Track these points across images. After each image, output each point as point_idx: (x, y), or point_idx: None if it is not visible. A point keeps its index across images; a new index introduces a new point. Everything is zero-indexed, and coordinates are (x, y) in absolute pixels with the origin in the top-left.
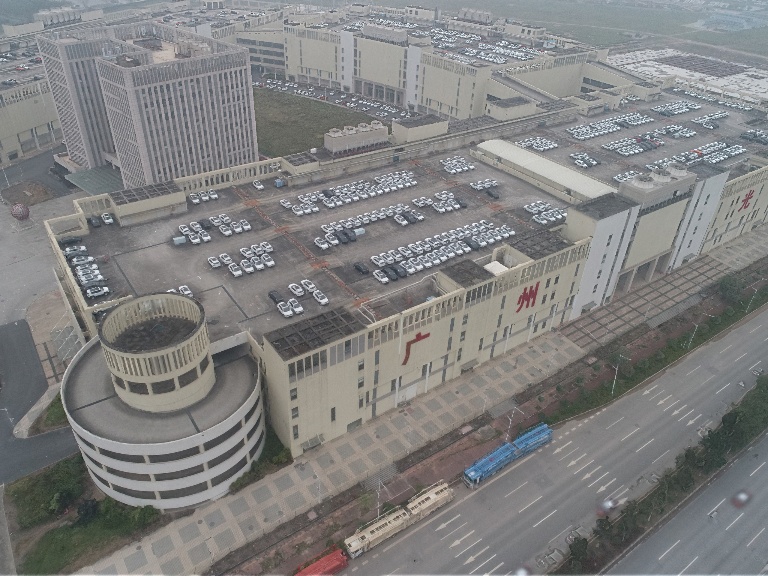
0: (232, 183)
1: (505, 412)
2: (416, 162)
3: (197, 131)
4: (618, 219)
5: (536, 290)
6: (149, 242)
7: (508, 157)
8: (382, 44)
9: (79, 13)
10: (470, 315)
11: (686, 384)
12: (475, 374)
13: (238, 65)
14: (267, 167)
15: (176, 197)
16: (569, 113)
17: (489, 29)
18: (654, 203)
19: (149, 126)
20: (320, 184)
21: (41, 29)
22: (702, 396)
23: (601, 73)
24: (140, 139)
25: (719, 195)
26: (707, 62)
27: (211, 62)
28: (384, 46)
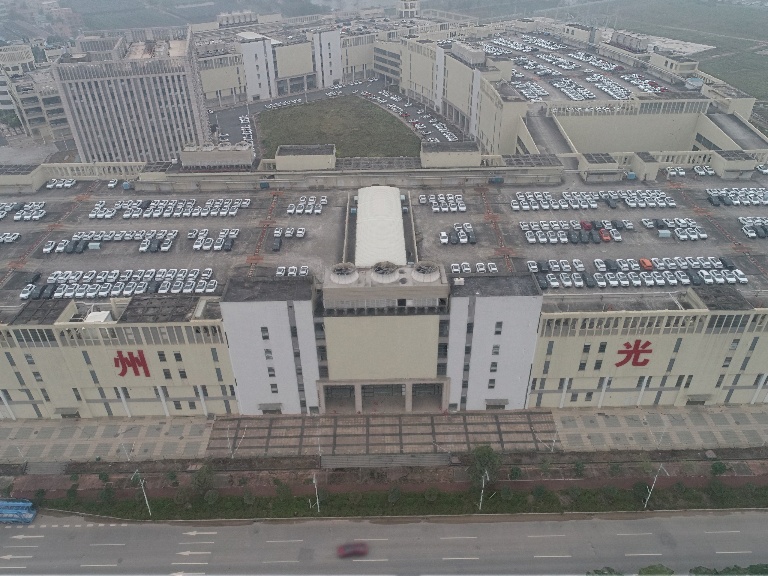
0: (98, 177)
1: (44, 473)
2: (278, 193)
3: (132, 127)
4: (267, 309)
5: (143, 359)
6: None
7: (362, 209)
8: (460, 64)
9: (256, 16)
10: (36, 357)
11: (247, 551)
12: (76, 424)
13: (175, 71)
14: (133, 169)
15: (22, 179)
16: (545, 173)
17: (635, 58)
18: (352, 305)
19: (79, 116)
20: (162, 194)
21: (216, 28)
22: (238, 575)
23: (713, 130)
24: (71, 126)
25: (534, 328)
26: None
27: (143, 65)
28: (461, 67)
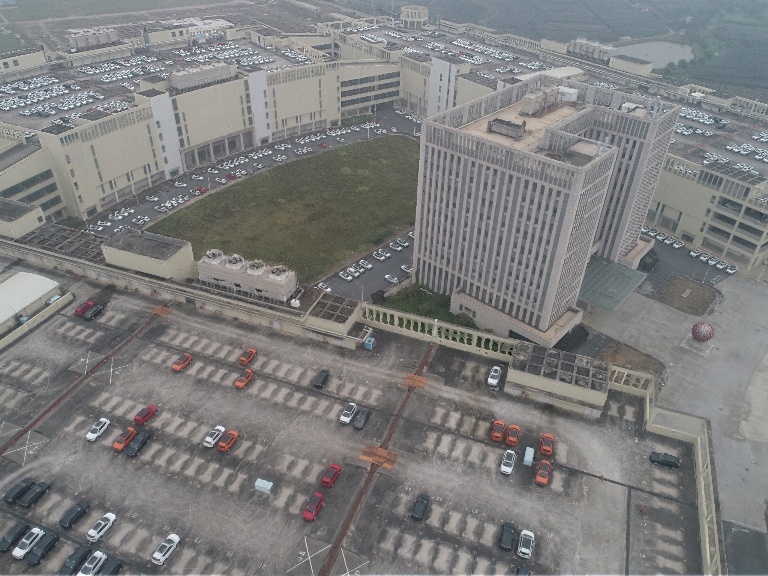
0: None
1: None
2: None
3: None
4: None
5: None
6: (767, 185)
7: None
8: (213, 88)
9: None
10: None
11: None
12: None
13: None
14: None
15: None
16: None
17: None
18: None
19: None
20: None
21: None
22: None
23: None
24: None
25: None
26: (130, 28)
27: None
28: (216, 90)
